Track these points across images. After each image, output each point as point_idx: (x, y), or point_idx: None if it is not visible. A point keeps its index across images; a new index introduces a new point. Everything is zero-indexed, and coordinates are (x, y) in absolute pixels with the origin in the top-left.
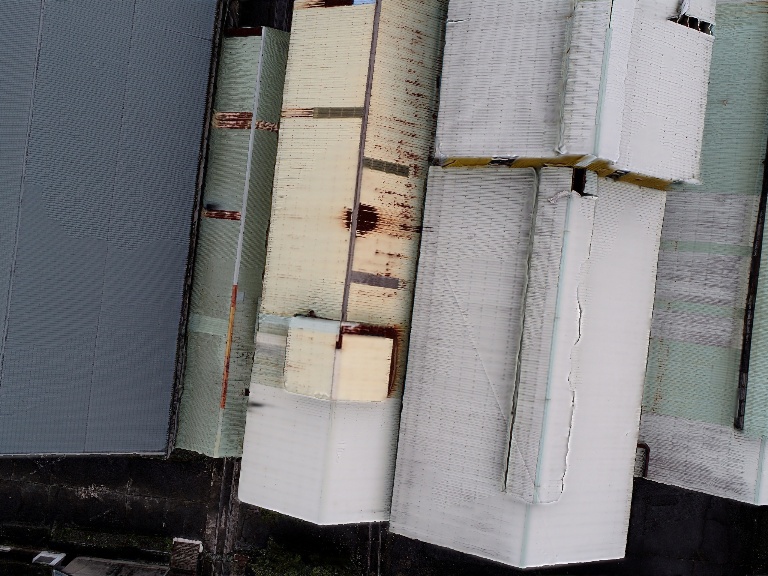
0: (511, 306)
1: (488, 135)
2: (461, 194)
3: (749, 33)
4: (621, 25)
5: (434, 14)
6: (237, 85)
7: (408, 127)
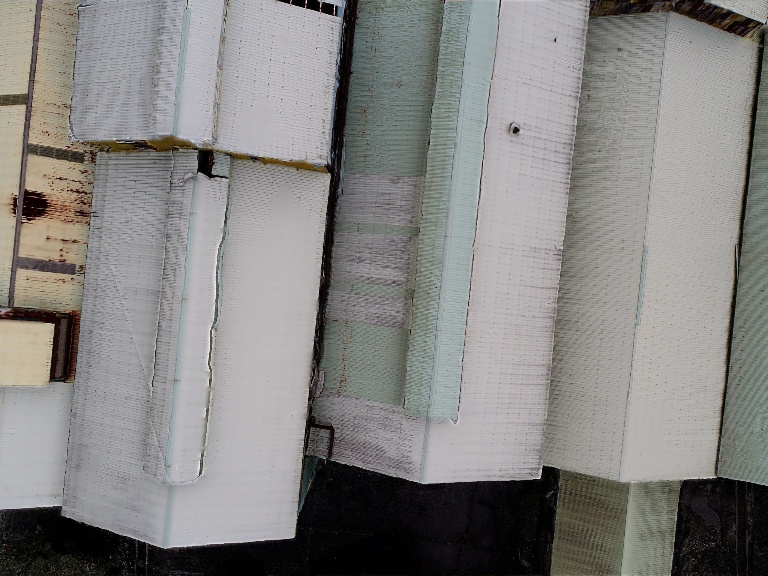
0: (159, 289)
1: (109, 118)
2: (121, 179)
3: (419, 15)
4: (200, 6)
5: None
6: None
7: None
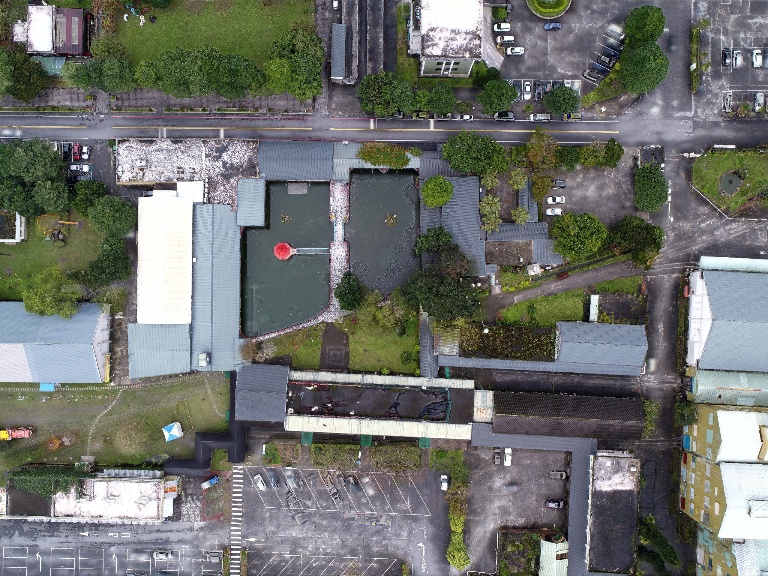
0: None
1: None
2: None
3: None
4: None
5: None
6: None
7: None
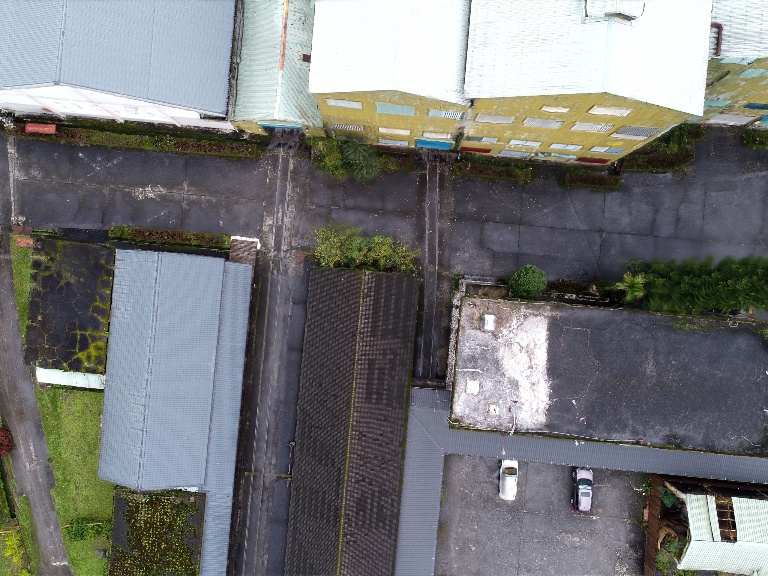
0: None
1: None
2: None
3: None
4: None
5: None
6: None
7: None
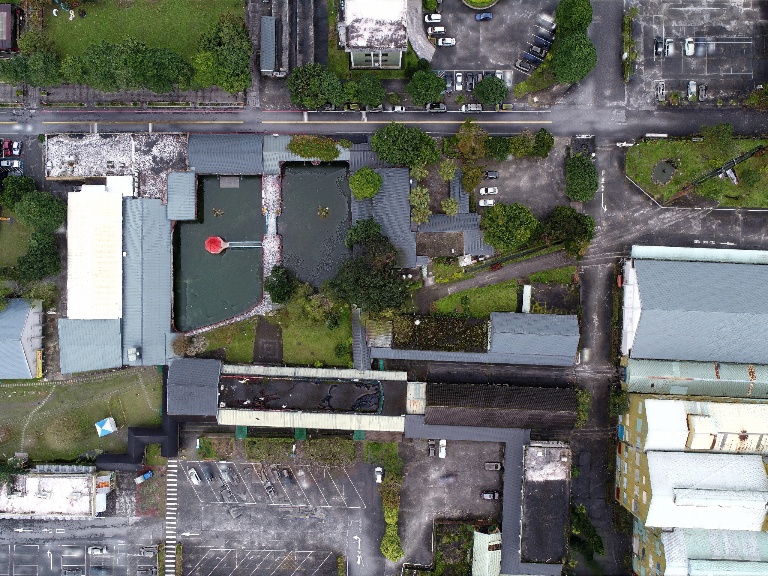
0: (727, 486)
1: None
2: (756, 467)
3: None
4: None
5: None
6: (765, 373)
7: None
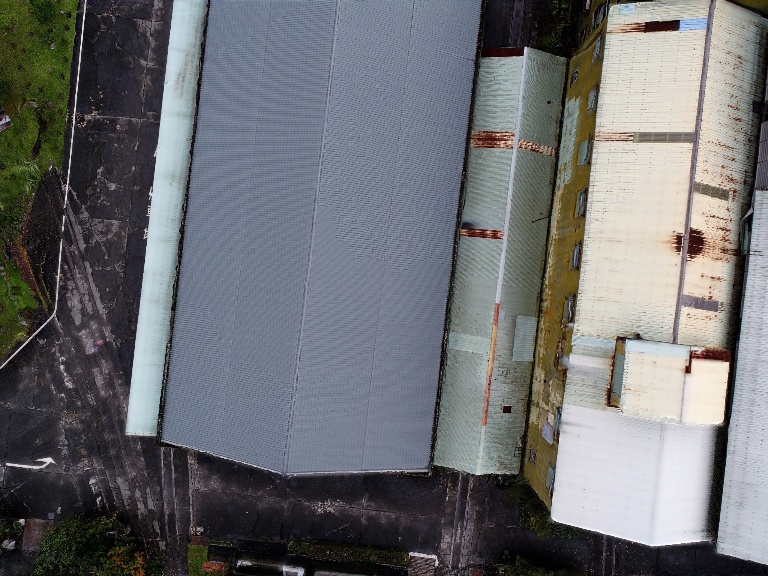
0: None
1: None
2: None
3: None
4: None
5: (752, 39)
6: (495, 105)
7: (729, 151)
